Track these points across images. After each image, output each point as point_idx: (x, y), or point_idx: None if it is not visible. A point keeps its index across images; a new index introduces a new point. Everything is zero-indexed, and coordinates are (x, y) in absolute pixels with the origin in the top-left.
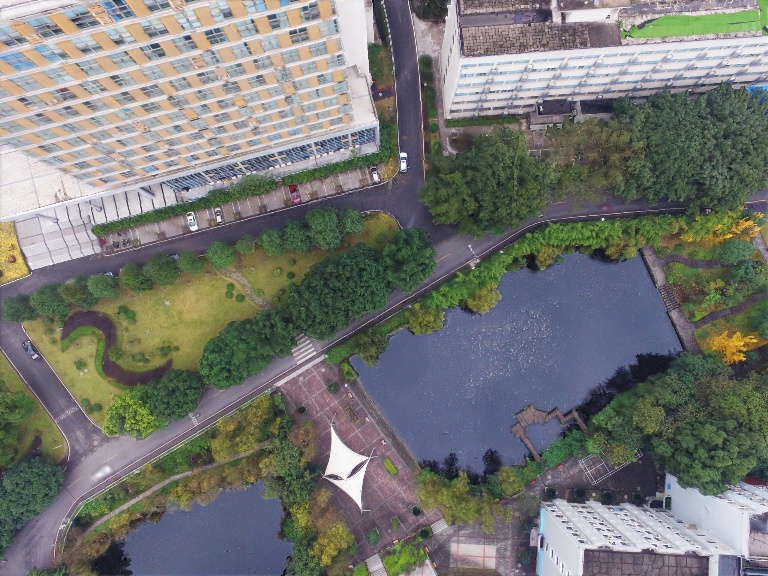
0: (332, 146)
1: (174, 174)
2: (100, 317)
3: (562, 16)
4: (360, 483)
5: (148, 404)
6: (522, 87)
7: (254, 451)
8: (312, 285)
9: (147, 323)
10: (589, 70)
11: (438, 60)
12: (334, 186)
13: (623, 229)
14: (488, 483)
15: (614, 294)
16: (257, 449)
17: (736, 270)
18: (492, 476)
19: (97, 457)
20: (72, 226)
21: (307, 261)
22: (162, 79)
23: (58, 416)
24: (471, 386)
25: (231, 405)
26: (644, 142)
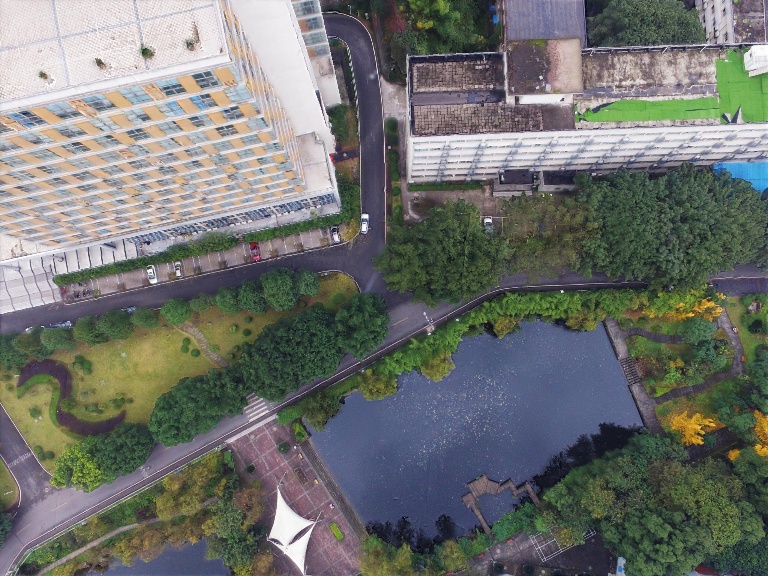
0: (292, 207)
1: (129, 234)
2: (57, 366)
3: (515, 98)
4: (304, 548)
5: (96, 458)
6: (480, 160)
7: (198, 511)
8: (262, 348)
9: (102, 373)
10: (546, 148)
11: (403, 123)
12: (295, 244)
13: (583, 302)
14: (435, 554)
15: (574, 365)
16: (207, 504)
17: (697, 350)
18: (439, 547)
19: (47, 504)
20: (34, 274)
21: (264, 319)
22: (92, 167)
23: (11, 461)
24: (424, 452)
25: (181, 459)
26: (600, 222)
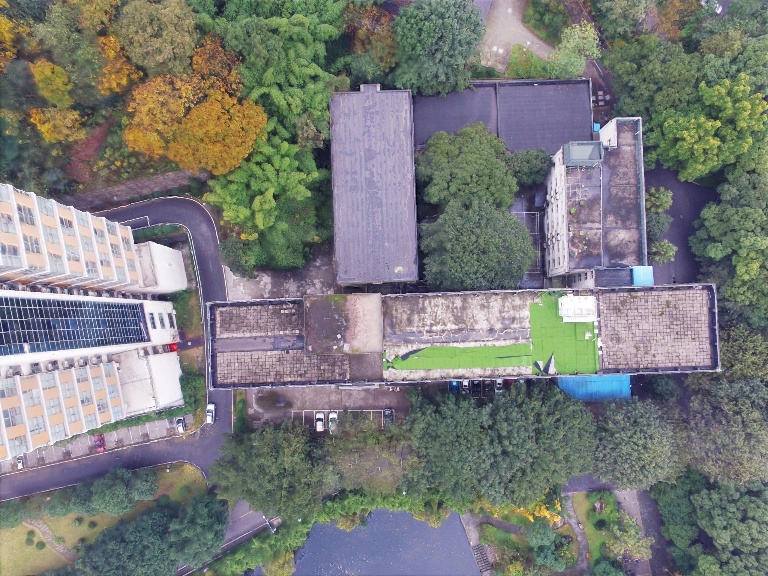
0: None
1: None
2: None
3: None
4: None
5: None
6: None
7: None
8: (95, 560)
9: None
10: None
11: None
12: (140, 434)
13: (427, 500)
14: None
15: (426, 551)
16: None
17: (536, 555)
18: None
19: None
20: None
21: None
22: None
23: None
24: None
25: None
26: (423, 451)
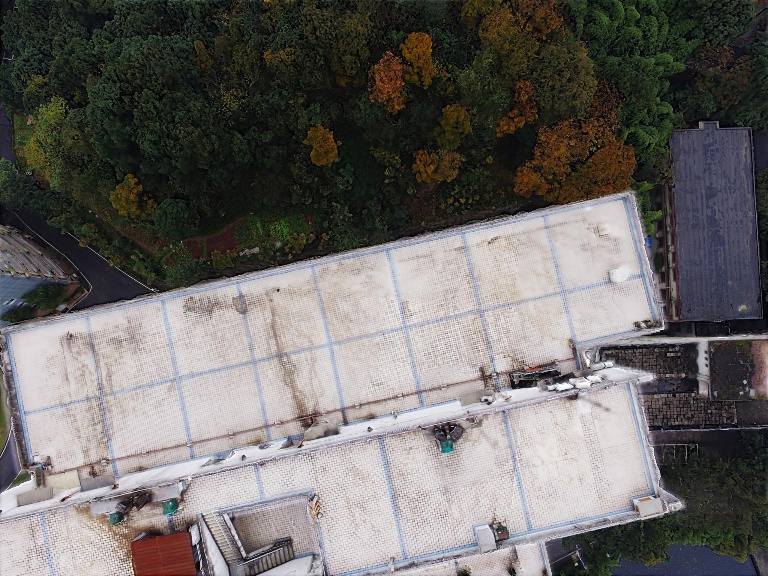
0: None
1: None
2: None
3: None
4: None
5: None
6: None
7: None
8: None
9: None
10: None
11: None
12: None
13: (735, 536)
14: None
15: None
16: None
17: None
18: None
19: None
20: None
21: None
22: None
23: None
24: None
25: None
26: None
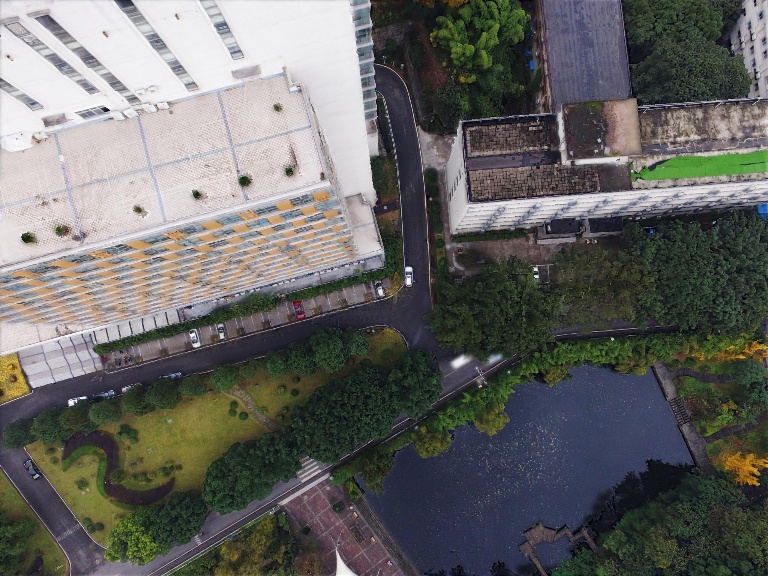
0: None
1: (176, 306)
2: (102, 436)
3: None
4: None
5: (150, 531)
6: (530, 215)
7: None
8: (317, 413)
9: (149, 442)
10: (598, 203)
11: (444, 173)
12: (338, 300)
13: (633, 347)
14: None
15: (624, 407)
16: None
17: (749, 392)
18: None
19: None
20: (73, 345)
21: (311, 378)
22: (164, 270)
23: (59, 535)
24: (478, 503)
25: (235, 524)
26: (655, 275)
